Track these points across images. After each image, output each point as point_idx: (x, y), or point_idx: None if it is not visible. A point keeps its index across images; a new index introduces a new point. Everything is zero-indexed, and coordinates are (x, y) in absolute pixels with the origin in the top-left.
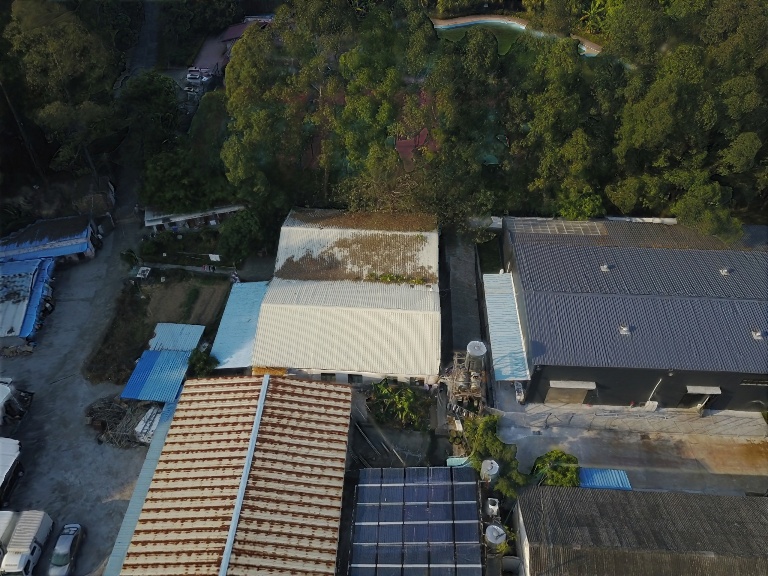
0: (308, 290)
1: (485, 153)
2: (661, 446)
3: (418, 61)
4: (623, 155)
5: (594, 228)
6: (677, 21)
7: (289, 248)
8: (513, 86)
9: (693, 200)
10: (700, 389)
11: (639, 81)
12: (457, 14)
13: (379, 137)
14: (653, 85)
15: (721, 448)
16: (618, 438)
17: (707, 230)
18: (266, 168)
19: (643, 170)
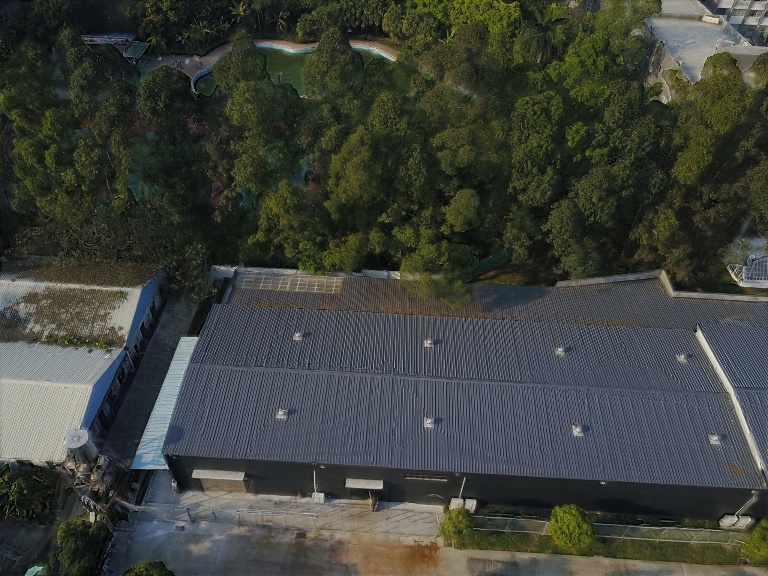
0: None
1: (219, 199)
2: (314, 547)
3: (84, 103)
4: (334, 210)
5: (331, 284)
6: (398, 65)
7: None
8: (213, 131)
9: (417, 260)
10: (360, 483)
11: (335, 131)
12: (317, 38)
13: None
14: (352, 136)
15: (381, 550)
16: (269, 536)
17: (424, 294)
18: None
19: (374, 224)
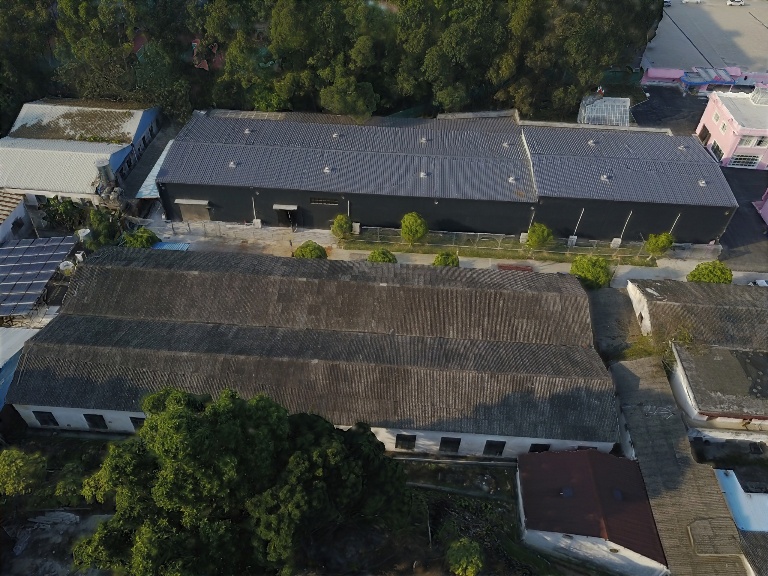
0: (25, 142)
1: None
2: (252, 247)
3: None
4: (275, 51)
5: (277, 116)
6: None
7: (25, 118)
8: None
9: None
10: (282, 206)
11: None
12: None
13: (94, 35)
14: None
15: None
16: (224, 242)
17: (336, 109)
18: (18, 61)
19: (305, 69)
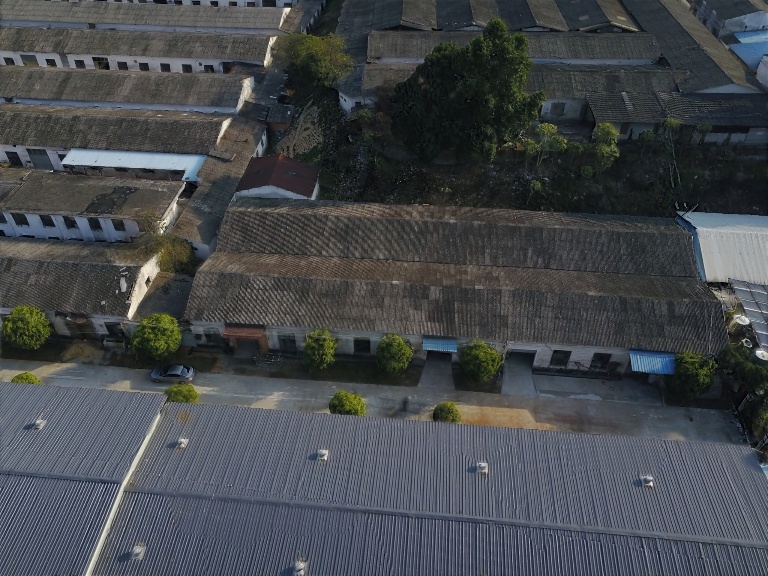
0: None
1: None
2: None
3: None
4: None
5: None
6: None
7: None
8: None
9: None
10: None
11: None
12: None
13: None
14: None
15: None
16: None
17: None
18: None
19: None
